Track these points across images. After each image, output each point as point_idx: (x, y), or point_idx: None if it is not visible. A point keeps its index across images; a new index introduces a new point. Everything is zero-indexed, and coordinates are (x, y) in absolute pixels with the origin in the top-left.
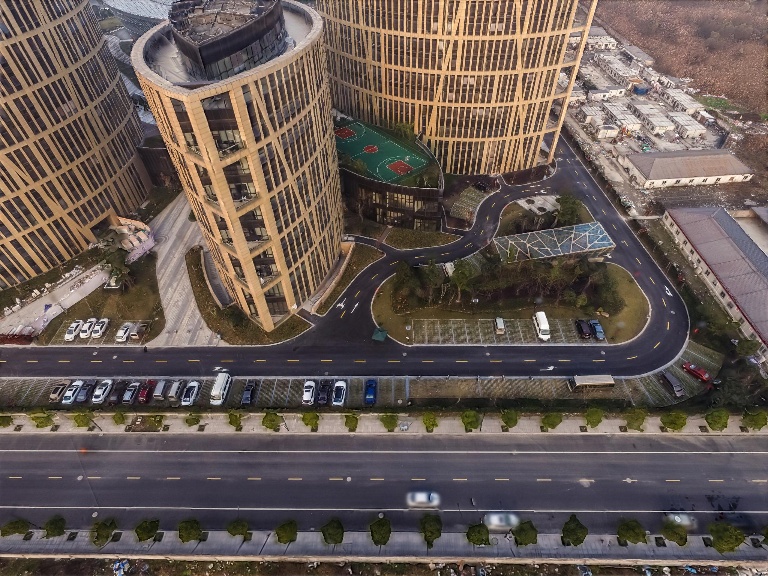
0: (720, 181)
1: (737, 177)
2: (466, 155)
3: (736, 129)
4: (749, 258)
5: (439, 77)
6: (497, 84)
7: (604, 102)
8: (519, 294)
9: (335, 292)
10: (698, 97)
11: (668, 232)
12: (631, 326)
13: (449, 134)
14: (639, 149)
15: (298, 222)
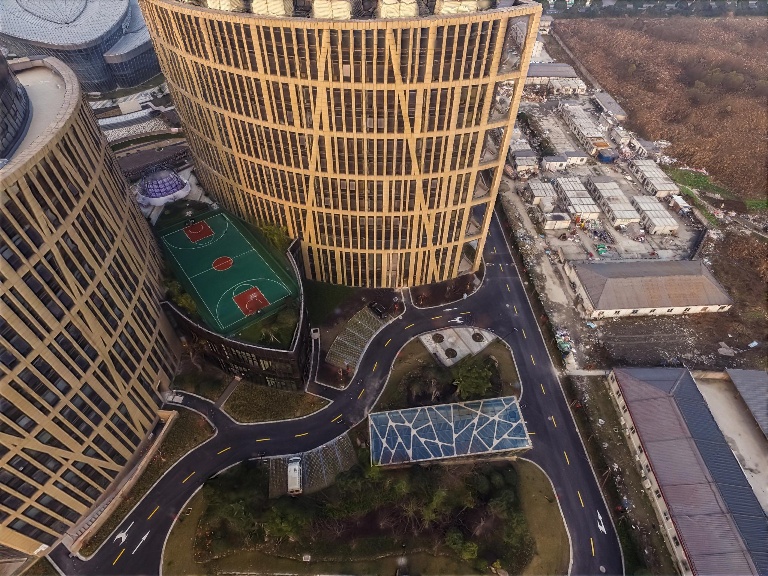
0: (689, 311)
1: (711, 307)
2: (360, 267)
3: (716, 223)
4: (716, 483)
5: (308, 177)
6: (388, 191)
7: (561, 172)
8: (384, 528)
9: (120, 510)
10: (674, 170)
11: (613, 402)
12: None
13: (333, 243)
14: (593, 250)
15: (4, 461)
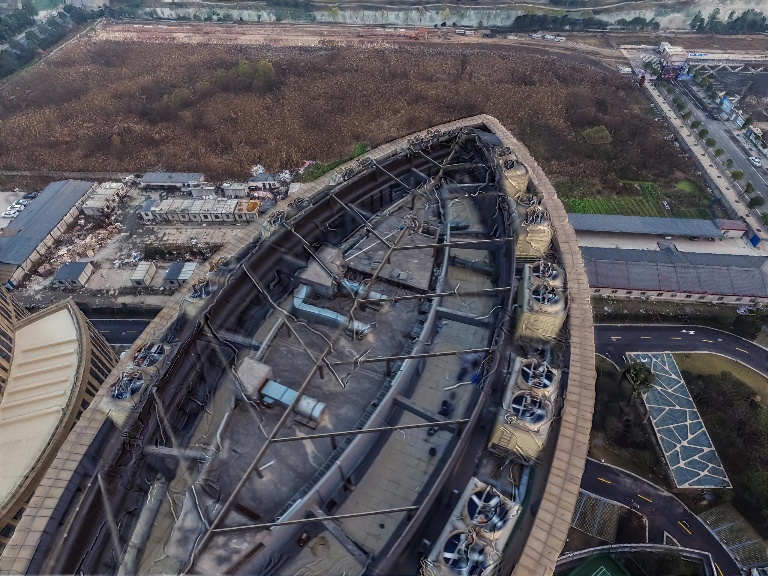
0: None
1: None
2: None
3: None
4: (655, 262)
5: None
6: None
7: None
8: None
9: None
10: (303, 177)
11: None
12: (761, 381)
13: None
14: None
15: None
